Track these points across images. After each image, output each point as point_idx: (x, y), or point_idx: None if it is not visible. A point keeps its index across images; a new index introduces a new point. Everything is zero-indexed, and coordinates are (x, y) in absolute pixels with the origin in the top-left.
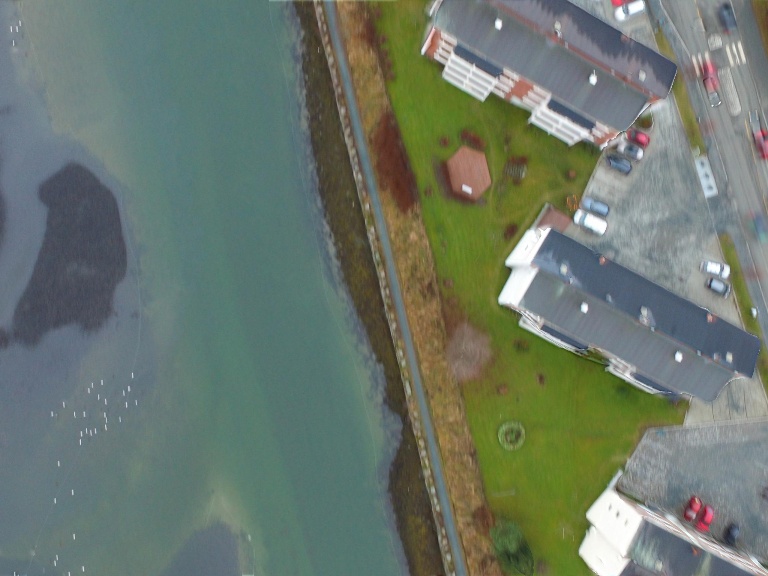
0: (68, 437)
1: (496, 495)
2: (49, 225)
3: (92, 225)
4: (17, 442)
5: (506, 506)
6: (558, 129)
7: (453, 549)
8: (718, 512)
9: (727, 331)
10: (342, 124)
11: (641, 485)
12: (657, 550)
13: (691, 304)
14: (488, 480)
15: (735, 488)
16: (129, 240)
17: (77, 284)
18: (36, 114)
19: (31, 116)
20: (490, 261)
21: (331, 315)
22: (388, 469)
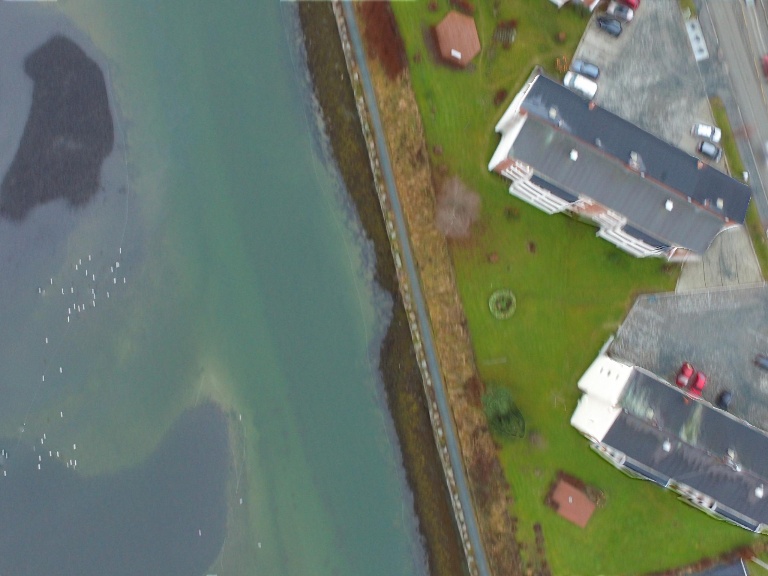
0: (56, 314)
1: (487, 363)
2: (35, 98)
3: (78, 98)
4: (4, 319)
5: (497, 376)
6: None
7: (445, 424)
8: (710, 379)
9: (718, 179)
10: None
11: (633, 352)
12: (648, 399)
13: (681, 152)
14: (479, 350)
15: (727, 355)
16: (116, 114)
17: (64, 158)
18: None
19: None
20: (480, 128)
21: (321, 191)
22: (379, 347)
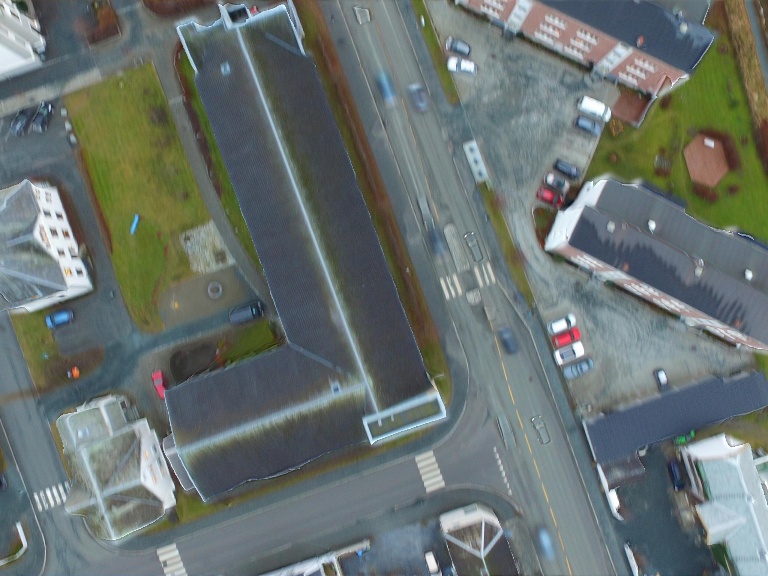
0: None
1: None
2: None
3: None
4: None
5: None
6: None
7: None
8: None
9: None
10: None
11: None
12: None
13: (543, 1)
14: None
15: None
16: None
17: None
18: None
19: None
20: None
21: None
22: None
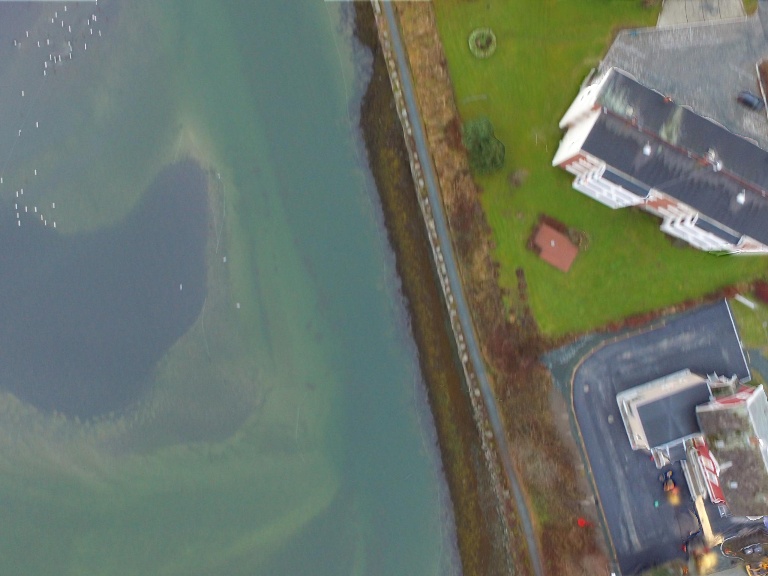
0: (32, 67)
1: (467, 99)
2: None
3: None
4: None
5: (478, 117)
6: None
7: (426, 175)
8: None
9: None
10: None
11: None
12: (627, 98)
13: None
14: (459, 91)
15: (710, 92)
16: None
17: None
18: None
19: None
20: None
21: None
22: (359, 104)
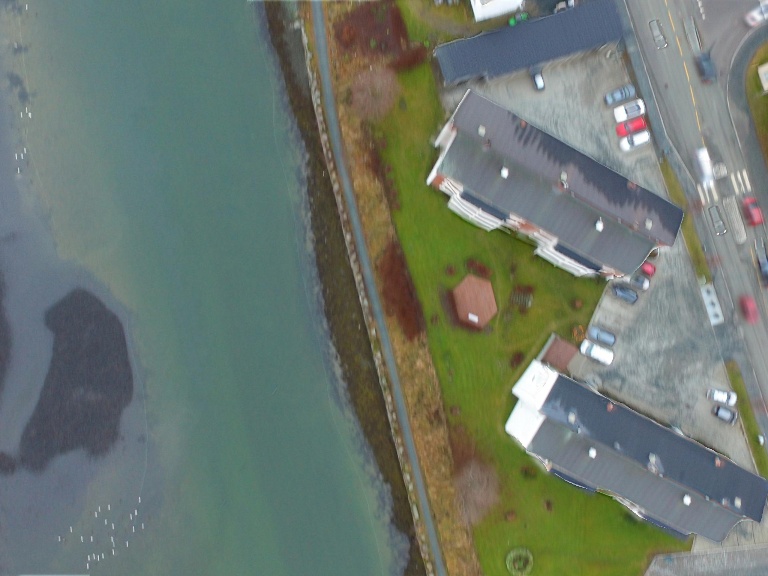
0: (75, 562)
1: None
2: (55, 351)
3: (98, 350)
4: (24, 567)
5: None
6: (564, 264)
7: None
8: None
9: (735, 475)
10: (348, 249)
11: None
12: None
13: (699, 448)
14: None
15: None
16: (135, 365)
17: (84, 409)
18: (41, 241)
19: (37, 243)
20: (497, 389)
21: (338, 435)
22: None
